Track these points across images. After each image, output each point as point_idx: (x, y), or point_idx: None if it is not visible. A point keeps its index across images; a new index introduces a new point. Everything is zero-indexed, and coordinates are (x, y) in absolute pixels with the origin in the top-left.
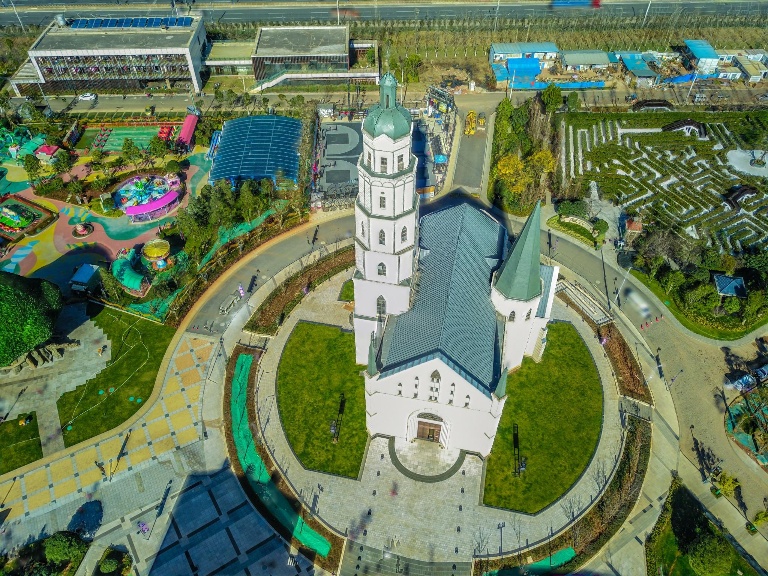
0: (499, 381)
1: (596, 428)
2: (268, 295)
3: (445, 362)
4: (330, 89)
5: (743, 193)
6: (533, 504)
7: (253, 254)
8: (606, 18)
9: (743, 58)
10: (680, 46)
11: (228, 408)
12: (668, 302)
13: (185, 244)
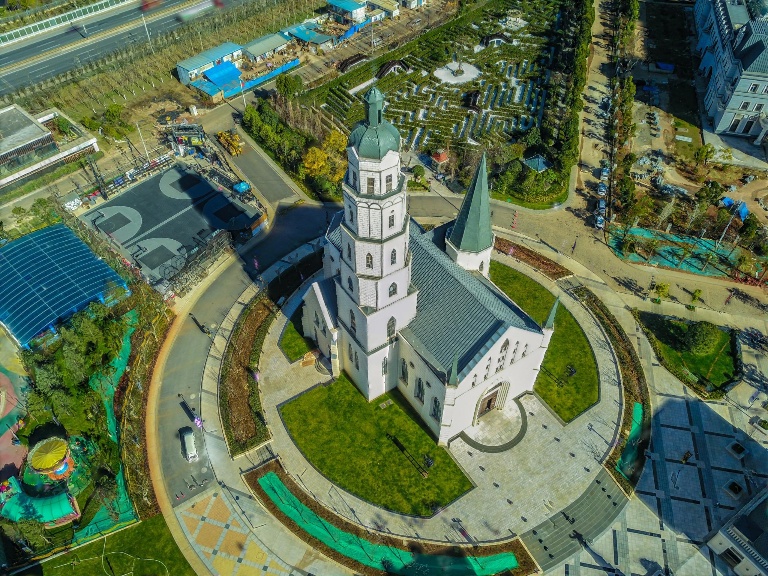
0: (551, 313)
1: (566, 314)
2: (220, 408)
3: (514, 326)
4: (48, 179)
5: (477, 97)
6: (591, 395)
7: (155, 384)
8: (256, 4)
9: (375, 0)
10: (320, 8)
11: (306, 534)
12: (509, 199)
13: (64, 428)
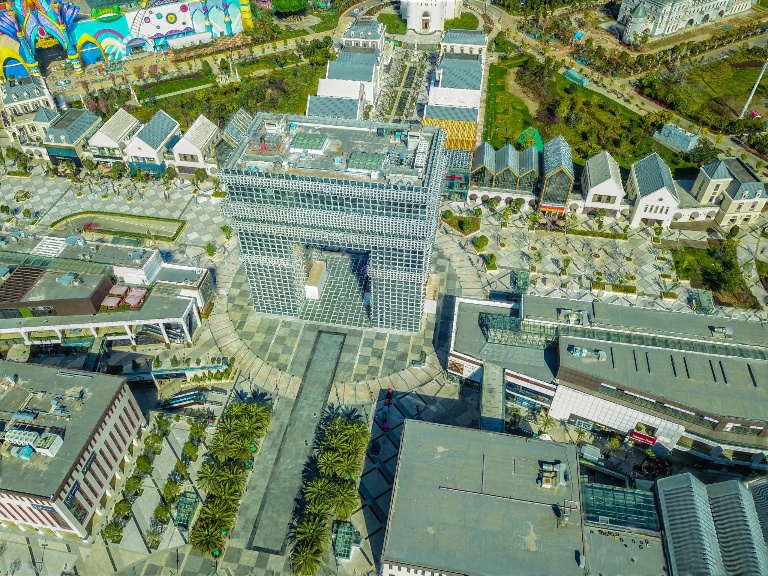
0: None
1: None
2: None
3: None
4: None
5: None
6: None
7: None
8: None
9: None
10: None
11: None
12: (506, 10)
13: (335, 1)
